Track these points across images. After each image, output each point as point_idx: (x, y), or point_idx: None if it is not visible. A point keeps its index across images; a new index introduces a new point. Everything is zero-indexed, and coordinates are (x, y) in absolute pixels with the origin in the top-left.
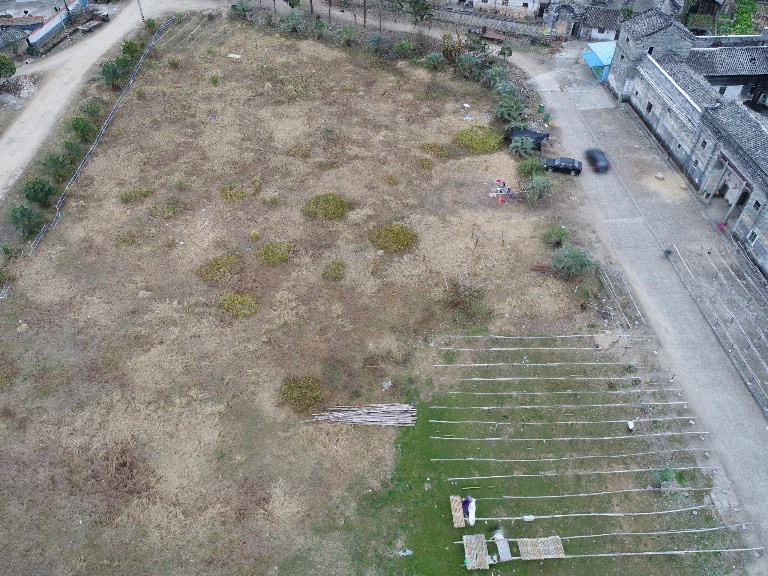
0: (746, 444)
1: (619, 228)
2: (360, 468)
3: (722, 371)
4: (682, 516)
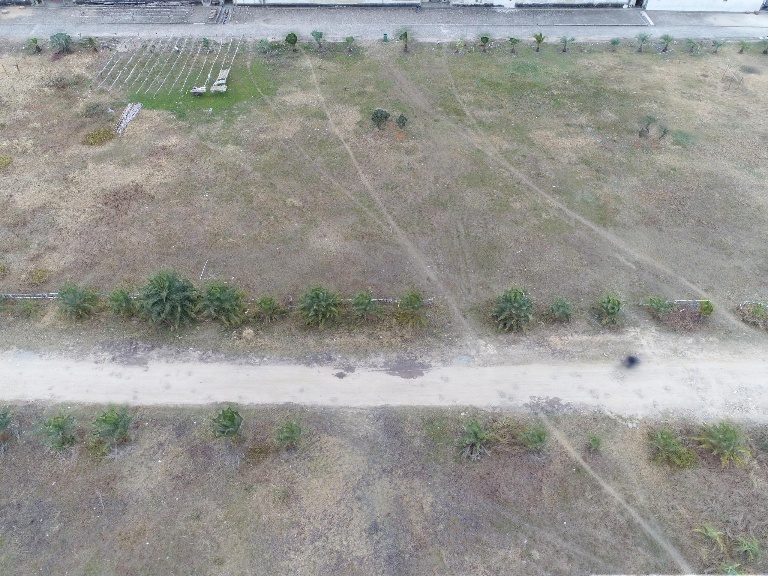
0: (199, 30)
1: (41, 32)
2: (160, 120)
3: (160, 27)
4: (223, 49)
